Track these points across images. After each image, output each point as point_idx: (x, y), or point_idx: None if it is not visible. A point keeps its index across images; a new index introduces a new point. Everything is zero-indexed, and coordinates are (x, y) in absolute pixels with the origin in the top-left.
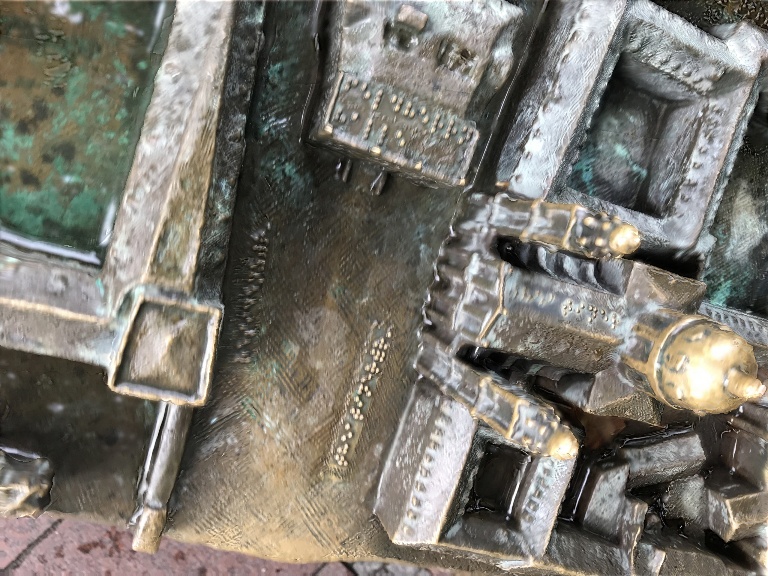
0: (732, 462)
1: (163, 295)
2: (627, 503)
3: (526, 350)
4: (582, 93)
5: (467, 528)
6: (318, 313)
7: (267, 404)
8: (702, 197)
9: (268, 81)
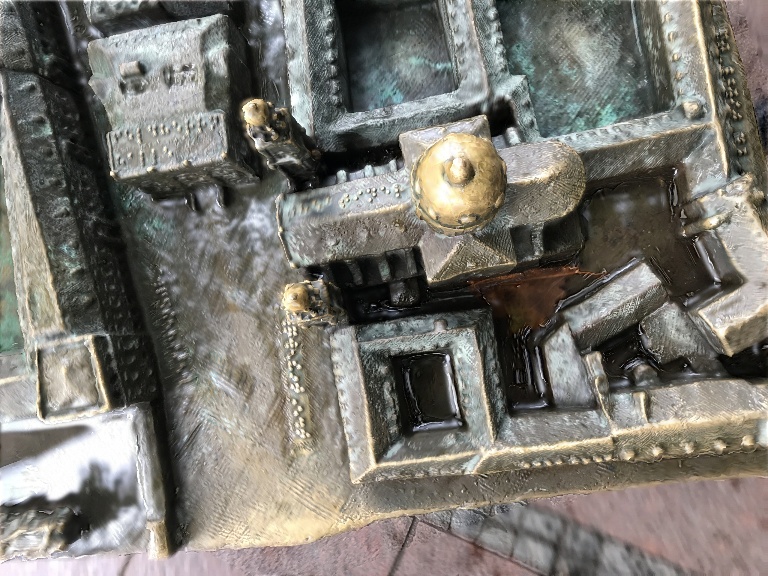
0: (714, 274)
1: (50, 341)
2: (583, 361)
3: (335, 254)
4: (302, 39)
5: (411, 444)
6: (227, 319)
7: (220, 409)
8: (473, 50)
9: None
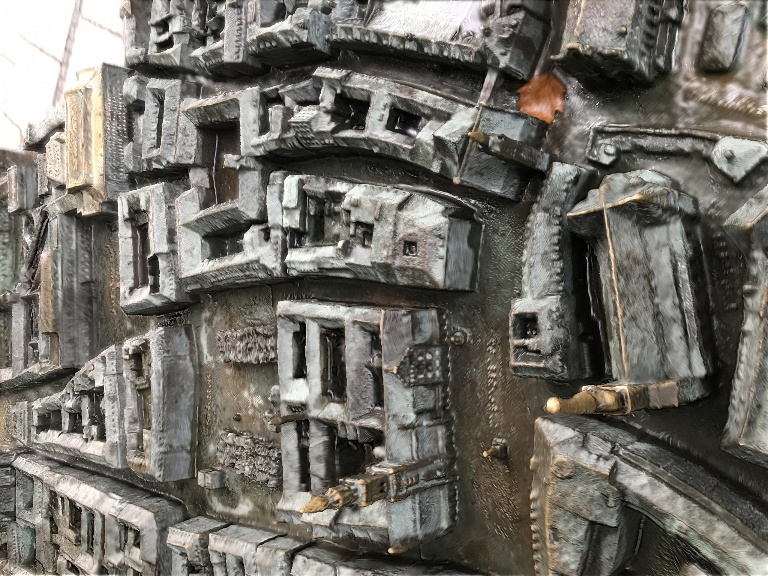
0: None
1: None
2: None
3: None
4: None
5: None
6: None
7: None
8: None
9: None
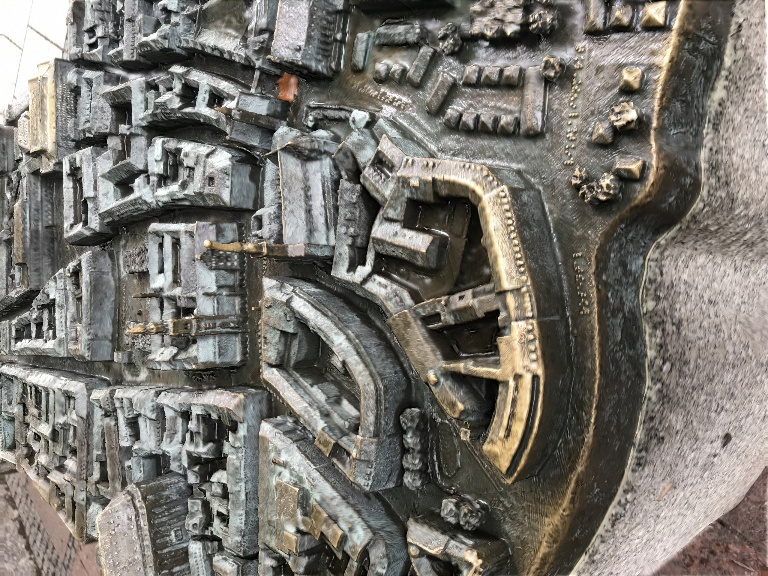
0: None
1: None
2: None
3: None
4: None
5: None
6: None
7: None
8: None
9: None
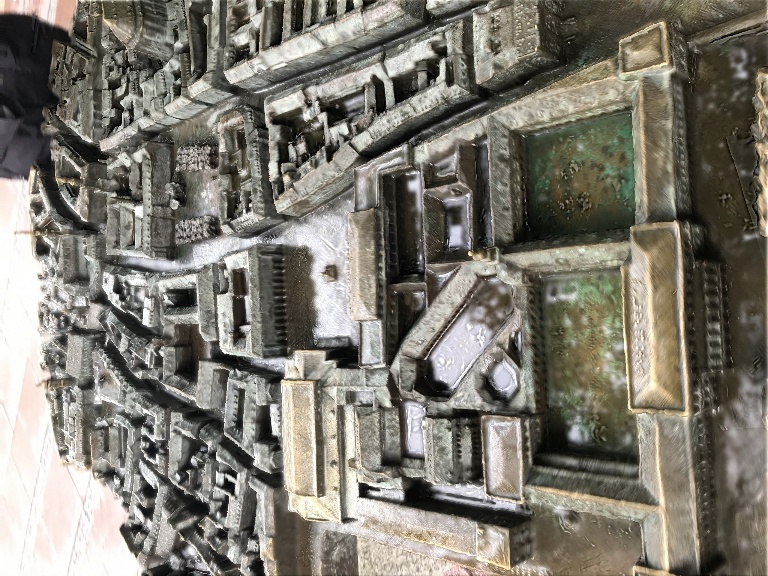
0: None
1: None
2: None
3: None
4: None
5: None
6: (643, 5)
7: None
8: None
9: None
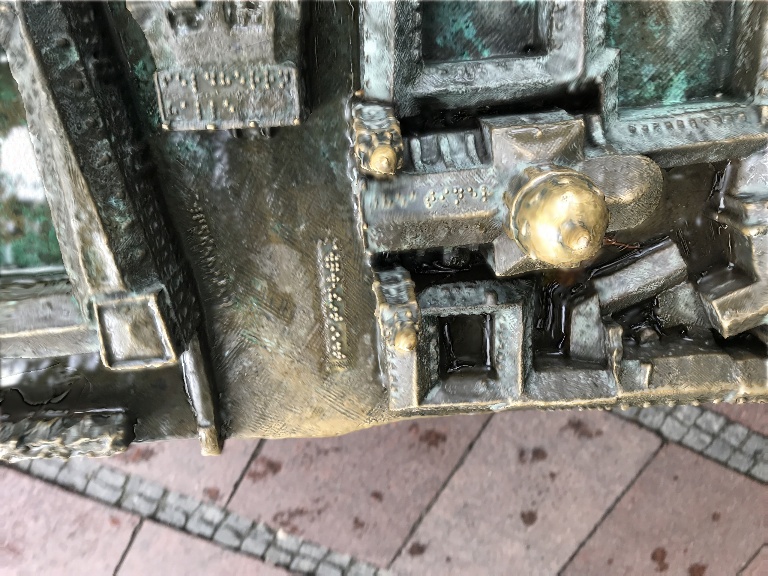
0: (730, 257)
1: (109, 297)
2: (604, 329)
3: (412, 245)
4: None
5: (447, 387)
6: (269, 250)
7: (261, 330)
8: (575, 19)
9: (139, 81)
